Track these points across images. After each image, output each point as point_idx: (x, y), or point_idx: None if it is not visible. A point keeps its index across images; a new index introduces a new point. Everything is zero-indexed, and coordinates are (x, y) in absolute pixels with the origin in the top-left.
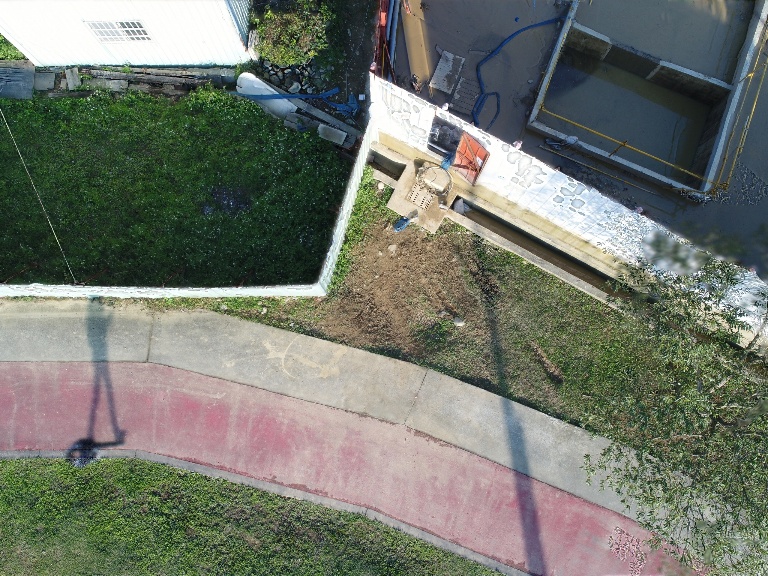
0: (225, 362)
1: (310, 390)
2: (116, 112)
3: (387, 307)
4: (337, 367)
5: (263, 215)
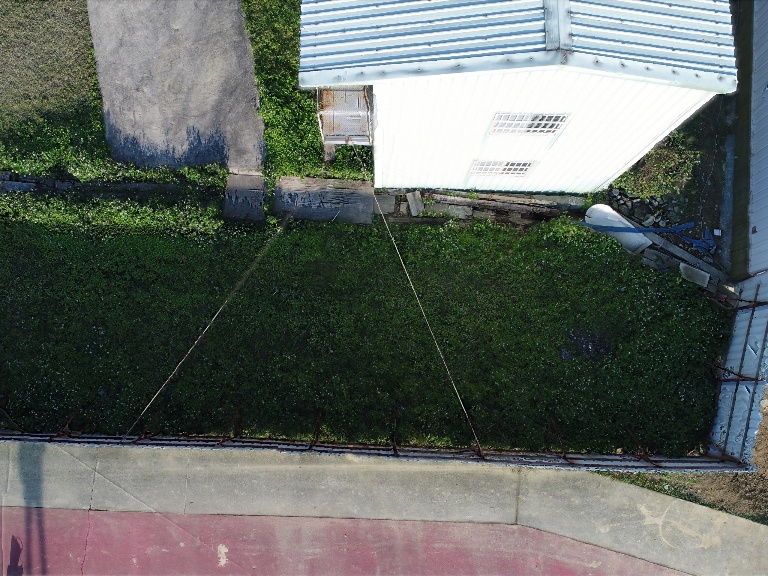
0: (599, 527)
1: (691, 561)
2: (466, 243)
3: (764, 469)
4: (718, 537)
5: (634, 365)
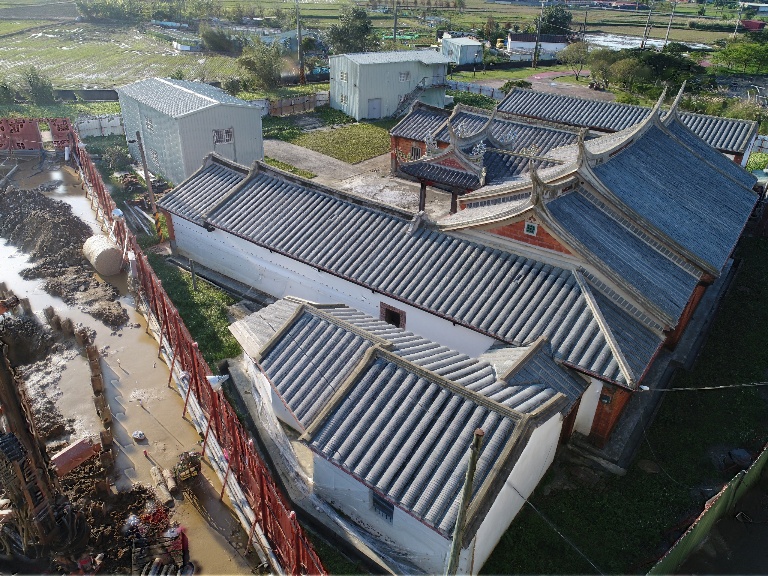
0: None
1: None
2: None
3: None
4: None
5: None
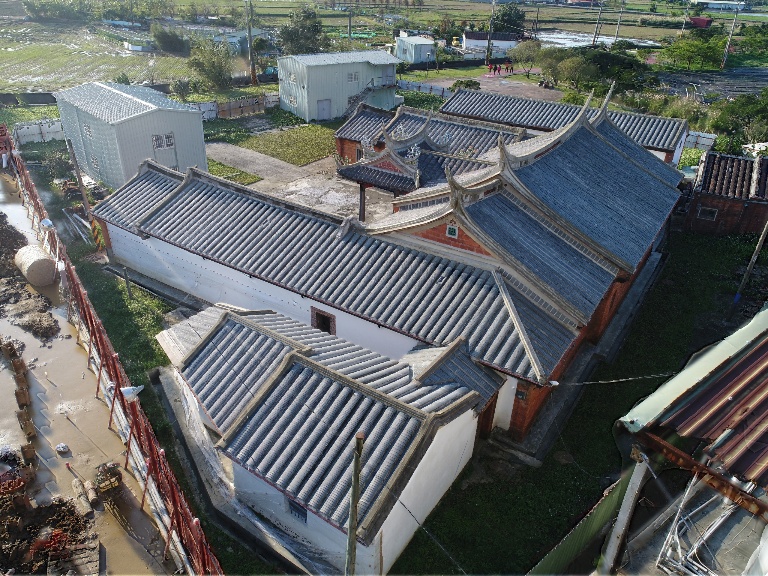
0: None
1: None
2: None
3: None
4: None
5: None
